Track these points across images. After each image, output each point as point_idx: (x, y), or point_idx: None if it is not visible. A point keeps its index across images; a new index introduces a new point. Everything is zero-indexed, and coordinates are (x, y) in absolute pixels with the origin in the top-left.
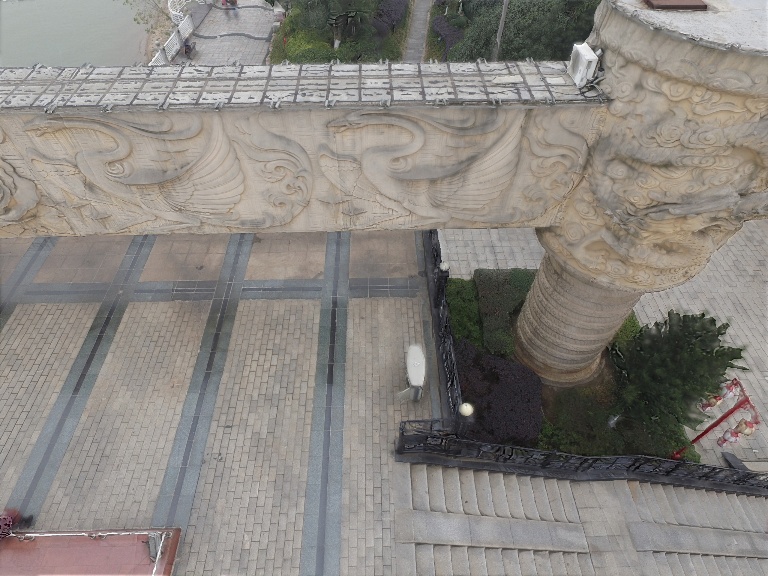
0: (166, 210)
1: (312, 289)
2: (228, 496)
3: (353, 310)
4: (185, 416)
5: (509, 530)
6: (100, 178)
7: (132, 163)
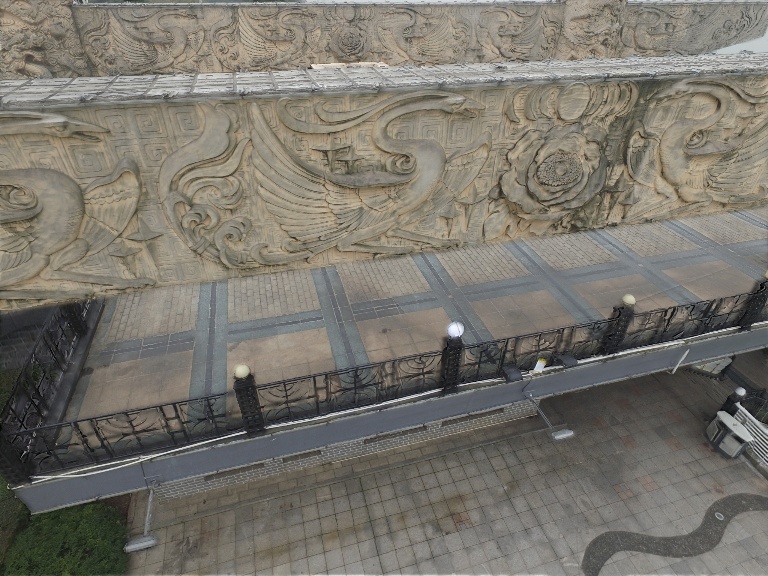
0: None
1: (240, 331)
2: None
3: (190, 319)
4: None
5: None
6: None
7: None
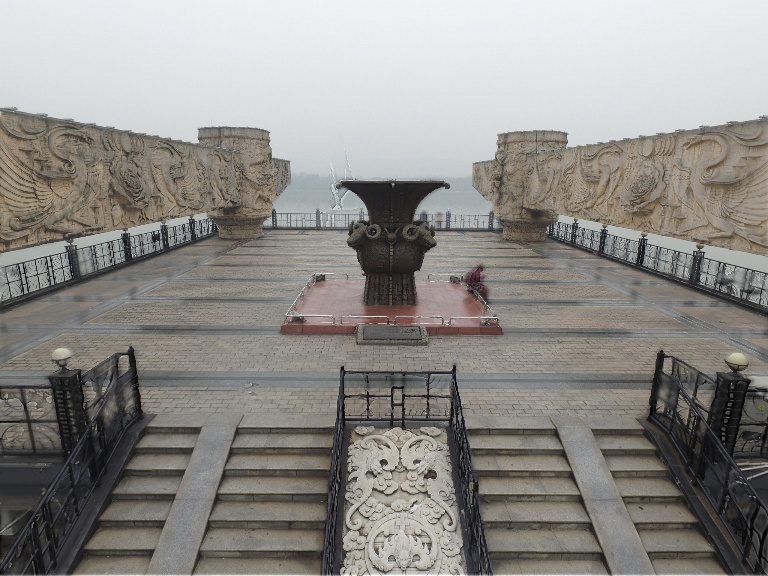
0: (717, 215)
1: None
2: (535, 346)
3: None
4: (581, 329)
5: (637, 572)
6: (696, 180)
7: (721, 170)
